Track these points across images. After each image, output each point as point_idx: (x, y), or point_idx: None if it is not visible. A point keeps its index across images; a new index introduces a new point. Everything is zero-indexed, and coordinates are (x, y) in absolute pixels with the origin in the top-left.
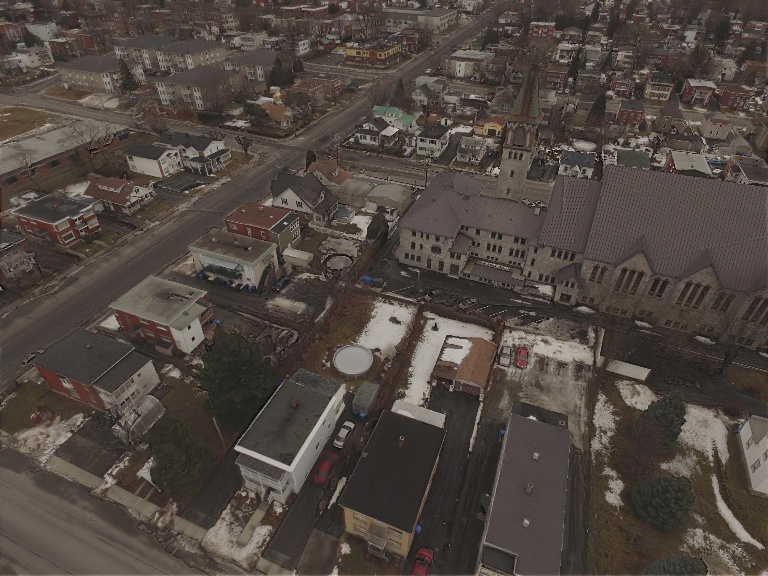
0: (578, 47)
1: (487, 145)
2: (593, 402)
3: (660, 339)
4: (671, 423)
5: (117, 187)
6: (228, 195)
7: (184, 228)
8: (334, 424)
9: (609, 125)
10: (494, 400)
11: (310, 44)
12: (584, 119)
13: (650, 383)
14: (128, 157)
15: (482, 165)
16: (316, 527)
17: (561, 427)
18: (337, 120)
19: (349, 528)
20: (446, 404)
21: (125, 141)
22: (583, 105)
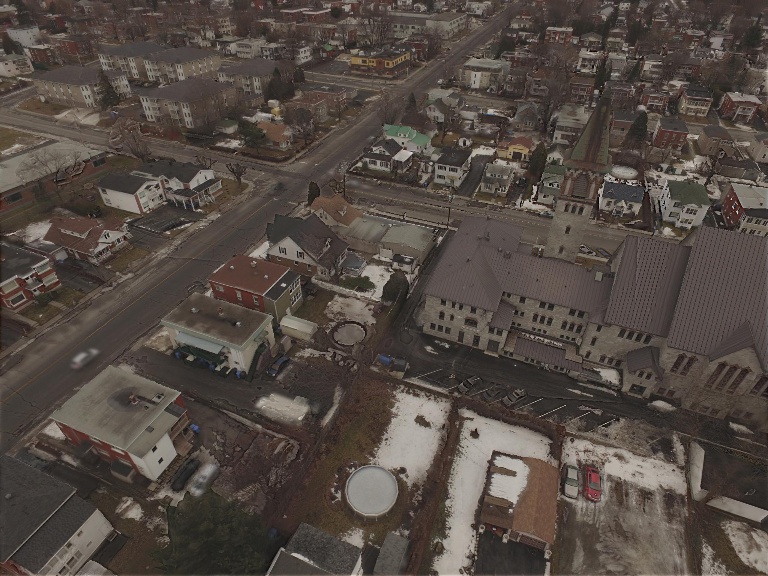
0: (603, 56)
1: None
2: (697, 559)
3: (767, 453)
4: None
5: (82, 232)
6: (217, 237)
7: (162, 283)
8: None
9: (651, 148)
10: (564, 558)
11: (312, 51)
12: (619, 139)
13: None
14: (101, 190)
15: (510, 196)
16: None
17: None
18: (342, 140)
19: None
20: (500, 565)
21: (101, 167)
22: (618, 124)
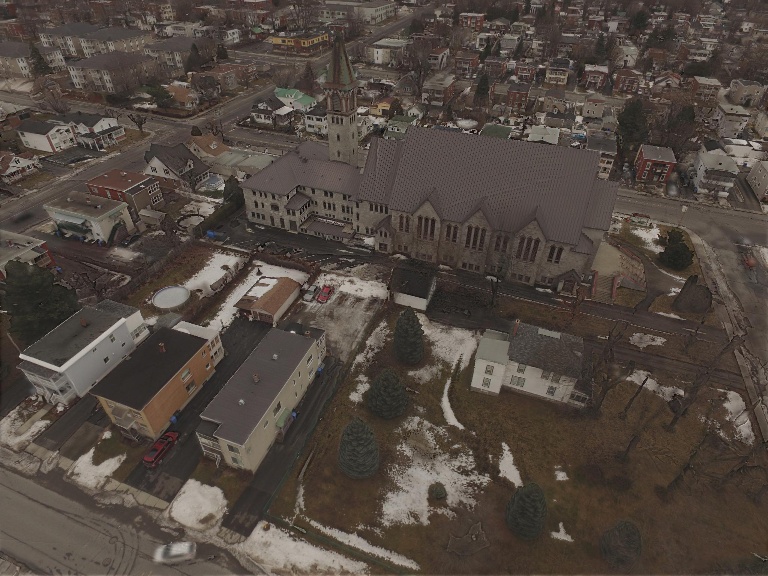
0: (492, 35)
1: (377, 123)
2: (373, 327)
3: (454, 279)
4: (407, 333)
5: None
6: (112, 167)
7: (59, 195)
8: (133, 345)
9: (491, 104)
10: None
11: (241, 33)
12: None
13: (429, 312)
14: (20, 133)
15: (365, 141)
16: (88, 420)
17: (307, 336)
18: (244, 102)
19: (112, 419)
20: (242, 330)
21: (27, 120)
22: (474, 87)
